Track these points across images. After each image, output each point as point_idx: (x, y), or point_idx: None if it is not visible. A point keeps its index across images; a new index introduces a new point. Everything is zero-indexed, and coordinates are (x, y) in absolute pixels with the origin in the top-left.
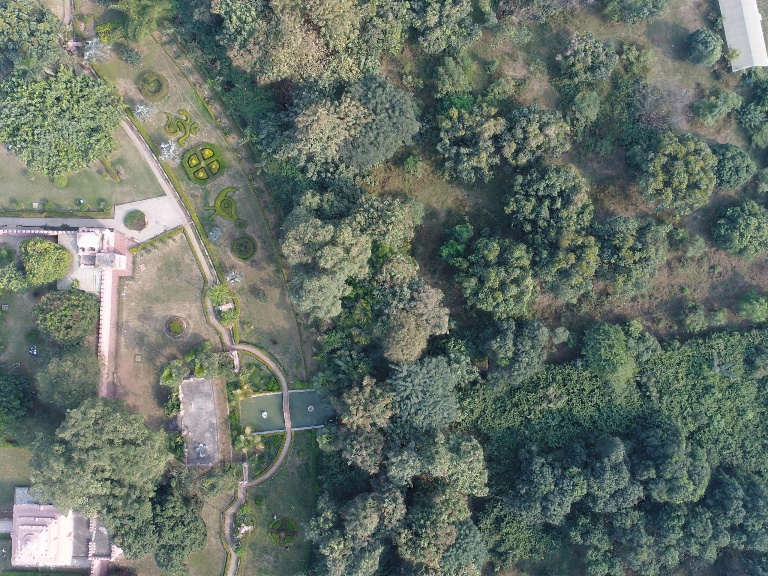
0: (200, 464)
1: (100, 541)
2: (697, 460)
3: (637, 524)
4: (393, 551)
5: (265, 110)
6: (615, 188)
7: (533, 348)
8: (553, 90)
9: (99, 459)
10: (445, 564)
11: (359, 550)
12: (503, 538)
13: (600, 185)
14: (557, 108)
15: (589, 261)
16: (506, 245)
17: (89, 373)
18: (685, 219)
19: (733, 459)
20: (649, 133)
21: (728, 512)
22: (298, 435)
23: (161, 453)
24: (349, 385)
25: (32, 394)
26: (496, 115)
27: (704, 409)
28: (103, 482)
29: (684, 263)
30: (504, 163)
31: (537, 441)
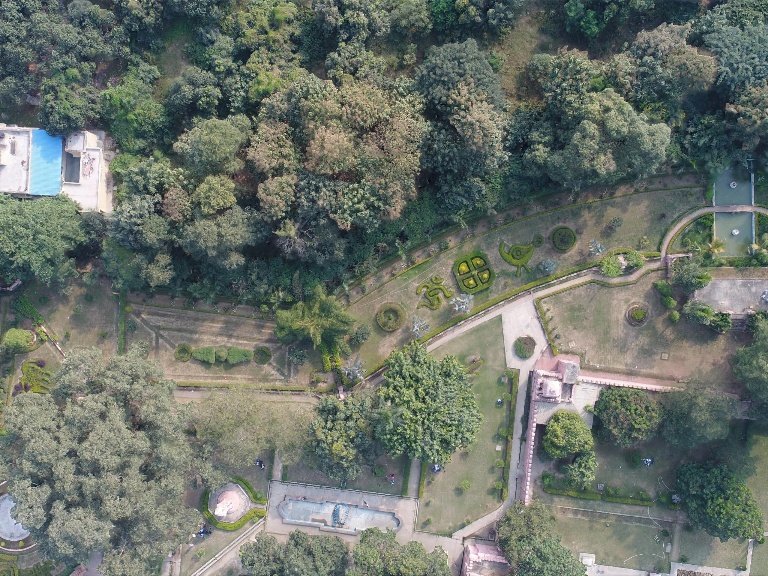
0: None
1: None
2: None
3: None
4: None
5: (432, 202)
6: None
7: None
8: None
9: None
10: None
11: None
12: None
13: None
14: None
15: None
16: None
17: None
18: None
19: None
20: None
21: None
22: (759, 201)
23: None
24: (727, 134)
25: None
26: None
27: None
28: None
29: None
30: None
31: None
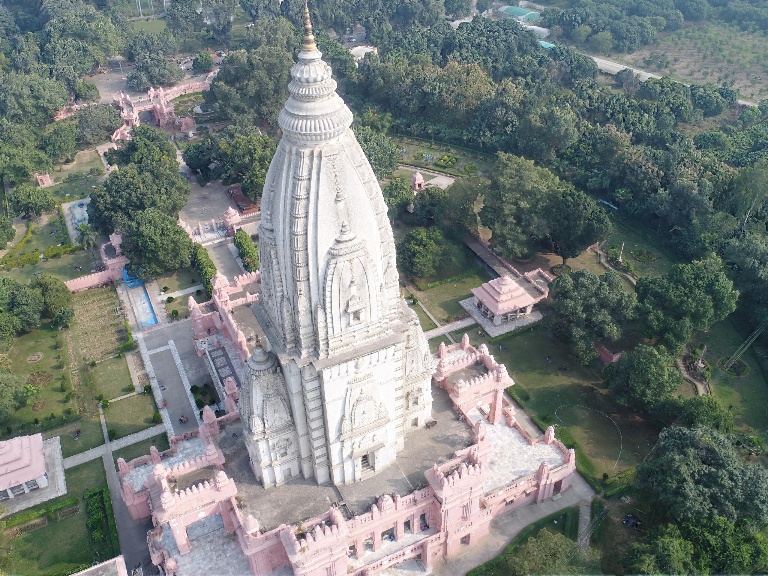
0: None
1: None
2: None
3: None
4: None
5: None
6: None
7: None
8: None
9: None
10: None
11: None
12: None
13: None
14: None
15: None
16: None
17: None
18: None
19: None
20: None
21: None
22: None
23: None
24: None
25: None
26: None
27: None
28: None
29: None
30: None
31: None
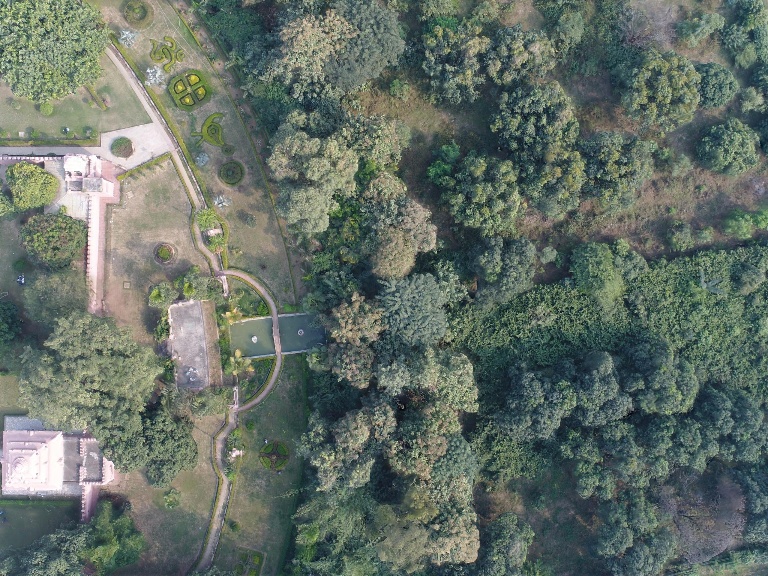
0: (190, 388)
1: (91, 466)
2: (685, 371)
3: (627, 436)
4: (385, 471)
5: (250, 33)
6: (600, 110)
7: (521, 264)
8: (537, 14)
9: (88, 368)
10: (436, 475)
11: (350, 463)
12: (494, 457)
13: (585, 107)
14: (542, 31)
15: (575, 176)
16: (493, 163)
17: (77, 296)
18: (670, 138)
19: (721, 375)
20: (633, 54)
21: (717, 422)
22: (288, 359)
23: (150, 366)
24: (338, 304)
25: (20, 321)
26: (481, 34)
27: (692, 326)
28: (92, 393)
29: (670, 183)
30: (490, 86)
31: (527, 360)
